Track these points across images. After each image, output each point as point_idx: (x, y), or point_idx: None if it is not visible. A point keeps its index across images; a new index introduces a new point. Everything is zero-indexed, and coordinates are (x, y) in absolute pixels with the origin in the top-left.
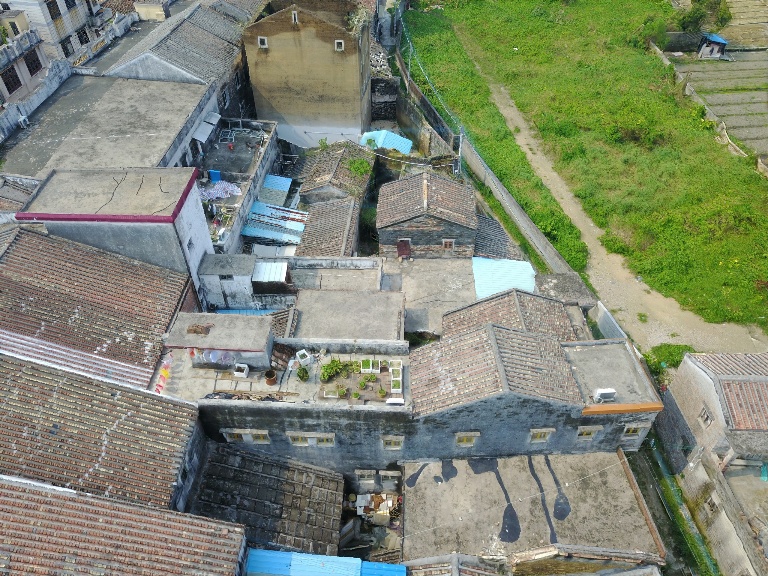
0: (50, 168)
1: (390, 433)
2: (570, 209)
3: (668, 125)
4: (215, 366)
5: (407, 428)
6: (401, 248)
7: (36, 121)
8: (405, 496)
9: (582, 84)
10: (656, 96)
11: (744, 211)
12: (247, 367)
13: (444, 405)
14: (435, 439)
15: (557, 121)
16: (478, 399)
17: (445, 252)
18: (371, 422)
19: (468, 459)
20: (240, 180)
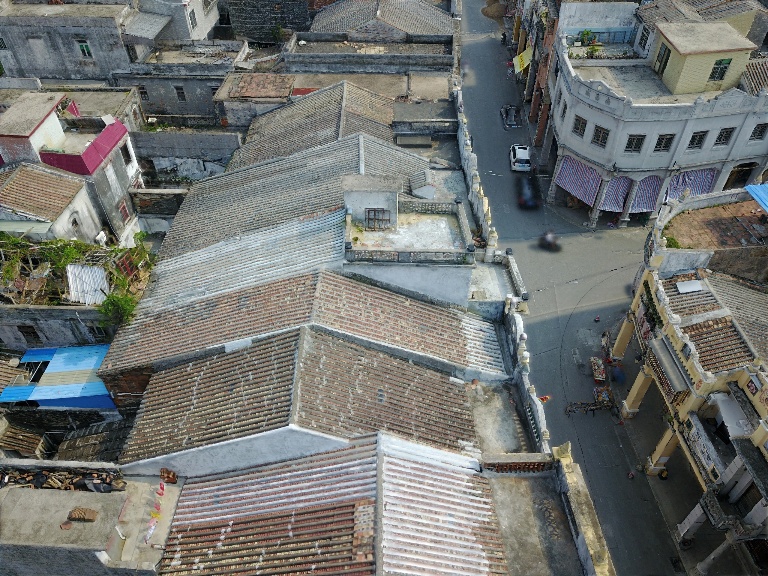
0: None
1: None
2: None
3: None
4: None
5: None
6: None
7: None
8: None
9: None
10: None
11: None
12: None
13: None
14: None
15: None
16: None
17: None
18: None
19: None
20: None
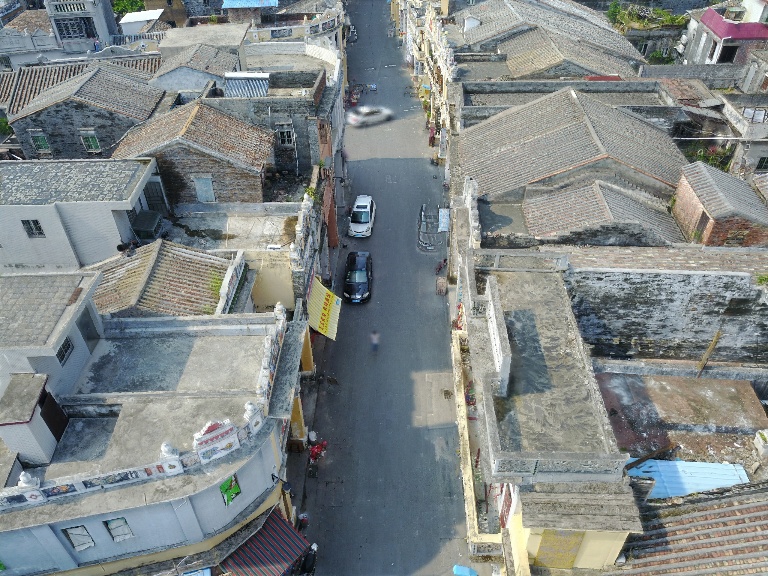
0: None
1: None
2: None
3: None
4: None
5: (646, 6)
6: None
7: None
8: None
9: None
10: None
11: None
12: None
13: None
14: None
15: None
16: None
17: None
18: (632, 2)
19: None
20: None
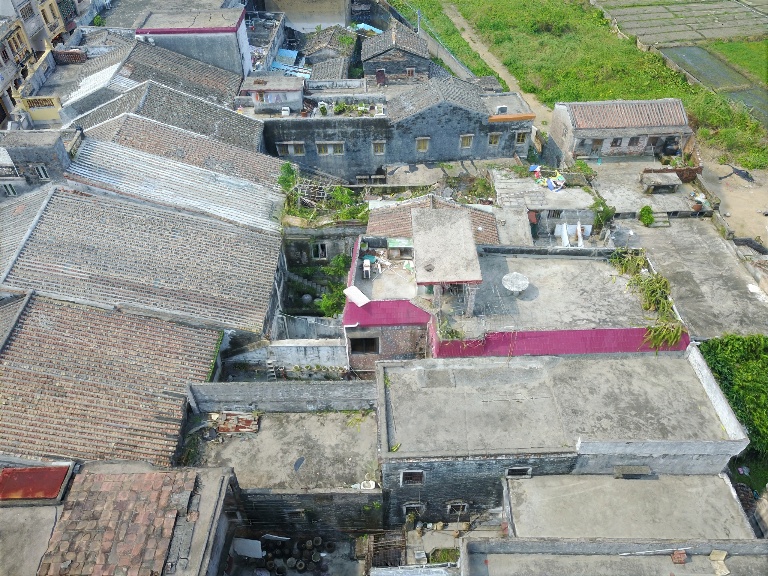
0: (136, 27)
1: (377, 139)
2: (499, 72)
3: (575, 22)
4: (269, 111)
5: (387, 133)
6: (379, 77)
7: (115, 6)
8: (388, 179)
9: (513, 0)
10: (569, 7)
11: (620, 66)
12: (289, 109)
13: (408, 115)
14: (404, 144)
15: (492, 21)
16: (427, 107)
17: (409, 79)
18: (366, 129)
19: (425, 164)
20: (263, 44)
